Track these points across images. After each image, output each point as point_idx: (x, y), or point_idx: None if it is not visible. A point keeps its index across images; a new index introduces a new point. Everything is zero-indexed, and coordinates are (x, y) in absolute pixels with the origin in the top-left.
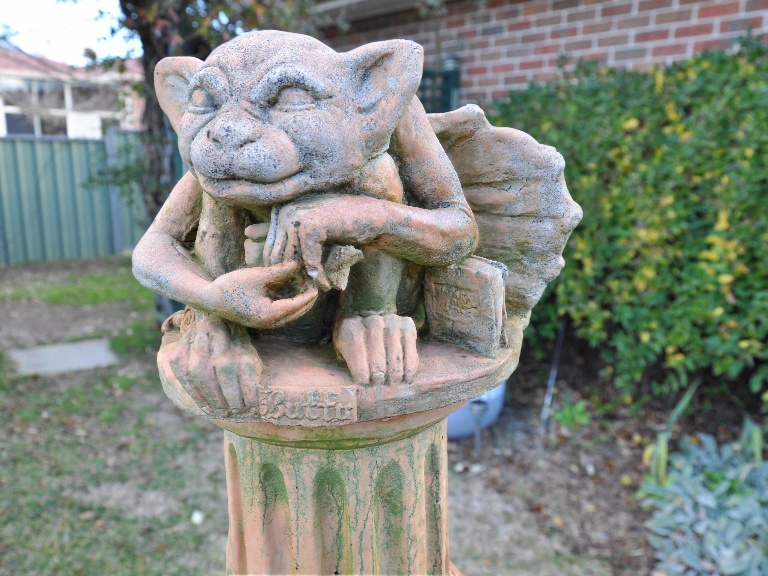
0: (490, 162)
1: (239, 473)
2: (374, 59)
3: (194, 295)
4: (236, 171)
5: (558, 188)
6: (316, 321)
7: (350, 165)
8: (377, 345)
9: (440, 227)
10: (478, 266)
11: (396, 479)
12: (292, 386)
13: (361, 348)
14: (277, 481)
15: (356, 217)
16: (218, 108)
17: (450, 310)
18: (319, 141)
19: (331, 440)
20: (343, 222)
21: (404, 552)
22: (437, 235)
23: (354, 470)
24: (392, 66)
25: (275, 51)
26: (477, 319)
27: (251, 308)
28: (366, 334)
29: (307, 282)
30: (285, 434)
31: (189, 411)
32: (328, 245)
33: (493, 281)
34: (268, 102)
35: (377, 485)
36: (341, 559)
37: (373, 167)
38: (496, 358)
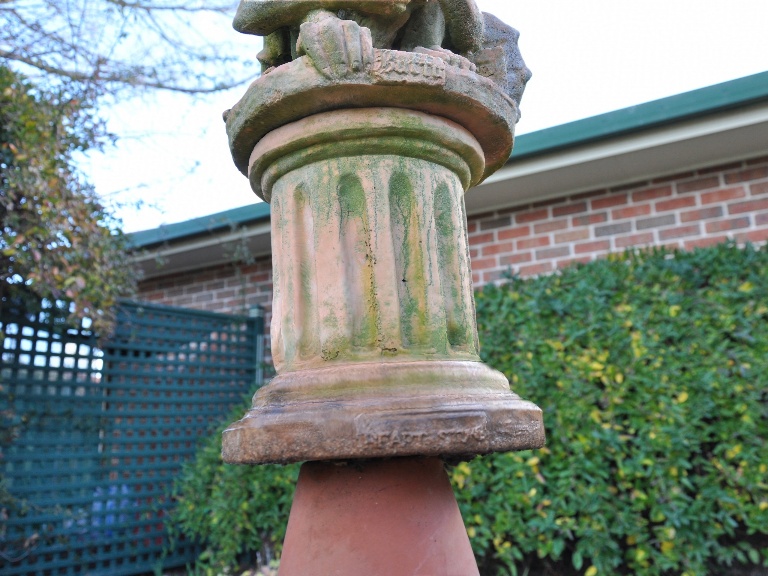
0: None
1: (301, 219)
2: None
3: None
4: None
5: (517, 49)
6: None
7: None
8: None
9: None
10: None
11: (446, 203)
12: None
13: None
14: (350, 198)
15: None
16: None
17: None
18: None
19: (411, 129)
20: None
21: (457, 268)
22: (473, 2)
23: (420, 176)
24: None
25: None
26: None
27: None
28: None
29: None
30: (376, 121)
31: (304, 86)
32: None
33: None
34: None
35: None
36: (408, 265)
37: None
38: None
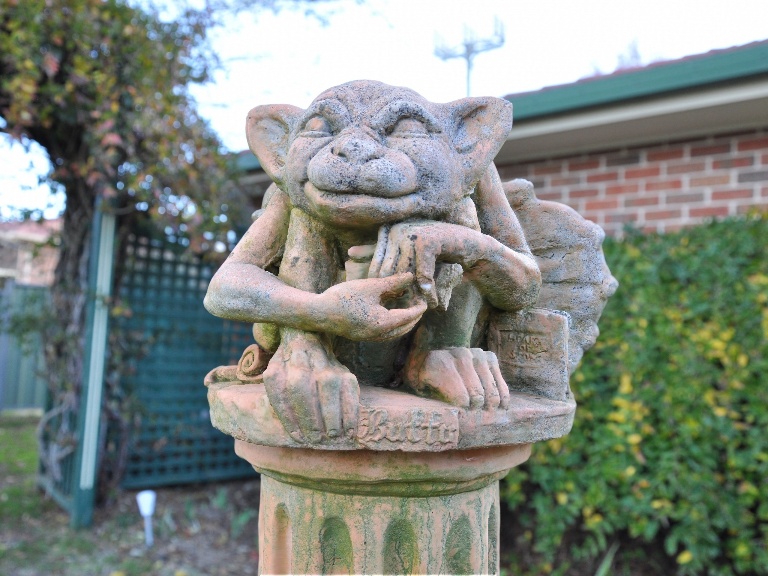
0: (536, 231)
1: (283, 541)
2: (470, 110)
3: (302, 305)
4: (361, 183)
5: (598, 256)
6: (387, 363)
7: (453, 195)
8: (471, 371)
9: (525, 263)
10: (546, 312)
11: (464, 538)
12: (394, 406)
13: (456, 374)
14: (337, 541)
15: (466, 237)
16: (334, 134)
17: (517, 357)
18: (436, 164)
19: (414, 479)
20: (456, 239)
21: None
22: (522, 270)
23: (428, 522)
24: (485, 117)
25: (388, 92)
26: (547, 363)
27: (369, 314)
28: (456, 363)
29: (416, 297)
30: (367, 472)
31: (269, 442)
32: (436, 263)
33: (563, 324)
34: (385, 130)
35: (445, 544)
36: None
37: (465, 204)
38: (567, 402)
